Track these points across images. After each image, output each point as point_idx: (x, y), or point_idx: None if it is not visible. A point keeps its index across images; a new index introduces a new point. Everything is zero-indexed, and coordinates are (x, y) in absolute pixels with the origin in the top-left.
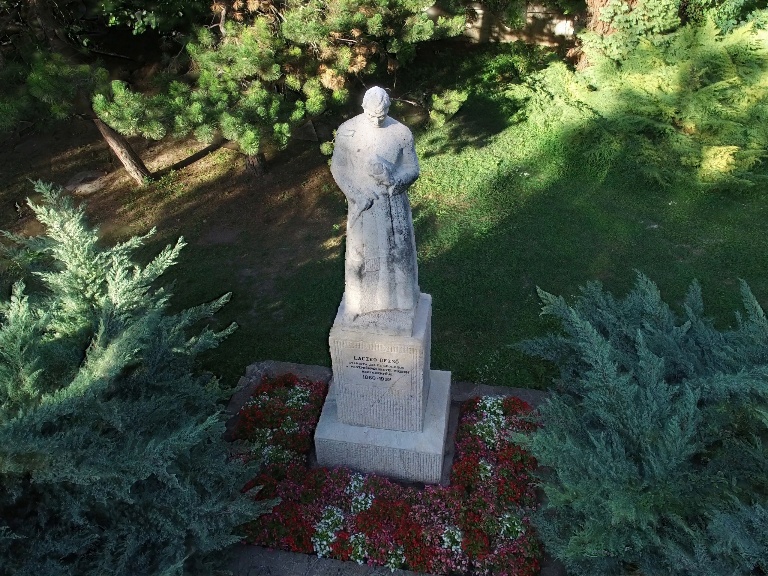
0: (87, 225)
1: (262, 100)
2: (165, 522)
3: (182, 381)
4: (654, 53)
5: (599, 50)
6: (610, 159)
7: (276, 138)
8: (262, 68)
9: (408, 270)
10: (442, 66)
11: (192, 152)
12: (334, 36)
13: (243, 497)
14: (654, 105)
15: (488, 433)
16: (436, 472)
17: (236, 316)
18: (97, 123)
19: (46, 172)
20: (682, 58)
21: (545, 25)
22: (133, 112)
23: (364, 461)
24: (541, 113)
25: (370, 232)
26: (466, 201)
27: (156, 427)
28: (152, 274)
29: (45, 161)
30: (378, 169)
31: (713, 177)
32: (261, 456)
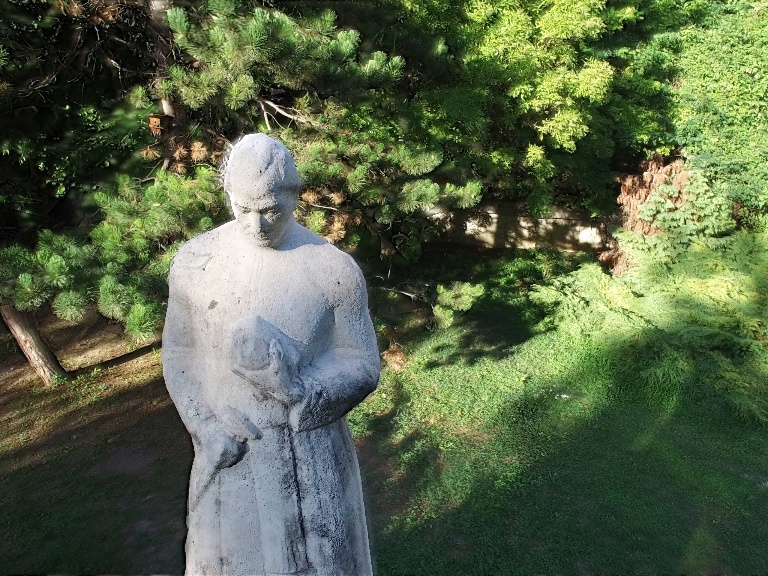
0: None
1: None
2: None
3: None
4: (711, 256)
5: (641, 251)
6: (678, 381)
7: None
8: (189, 224)
9: None
10: (451, 268)
11: (132, 348)
12: (307, 201)
13: None
14: (724, 315)
15: None
16: None
17: None
18: None
19: None
20: (745, 264)
21: (567, 232)
22: None
23: None
24: (575, 321)
25: (239, 526)
26: (481, 430)
27: None
28: None
29: None
30: (253, 354)
31: None
32: None
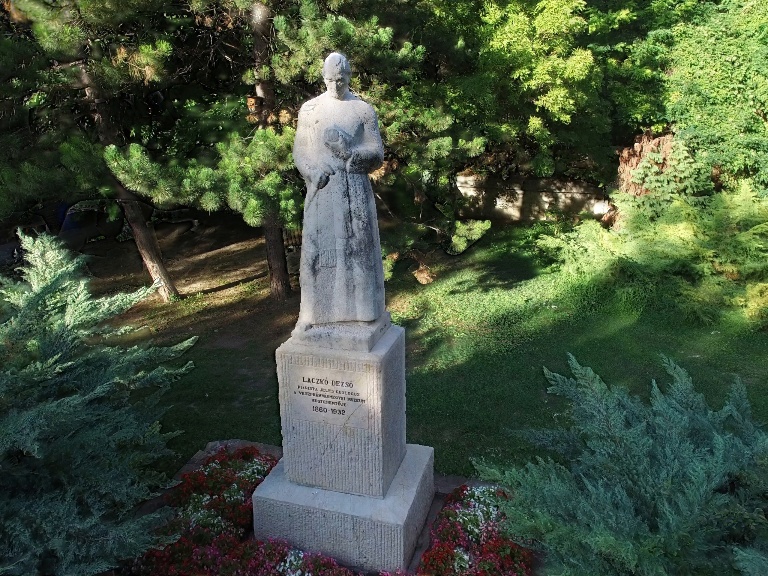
0: (78, 278)
1: (275, 185)
2: (23, 532)
3: (116, 414)
4: (688, 209)
5: None
6: (645, 296)
7: (282, 216)
8: (280, 159)
9: (368, 268)
10: None
11: (225, 282)
12: None
13: (132, 524)
14: None
15: (472, 521)
16: (397, 556)
17: (218, 405)
18: (135, 236)
19: (55, 231)
20: None
21: (584, 205)
22: (142, 167)
23: (310, 536)
24: (574, 263)
25: (326, 216)
26: (487, 327)
27: (60, 437)
28: (119, 309)
29: (58, 223)
30: (334, 136)
31: (762, 315)
32: (188, 519)
